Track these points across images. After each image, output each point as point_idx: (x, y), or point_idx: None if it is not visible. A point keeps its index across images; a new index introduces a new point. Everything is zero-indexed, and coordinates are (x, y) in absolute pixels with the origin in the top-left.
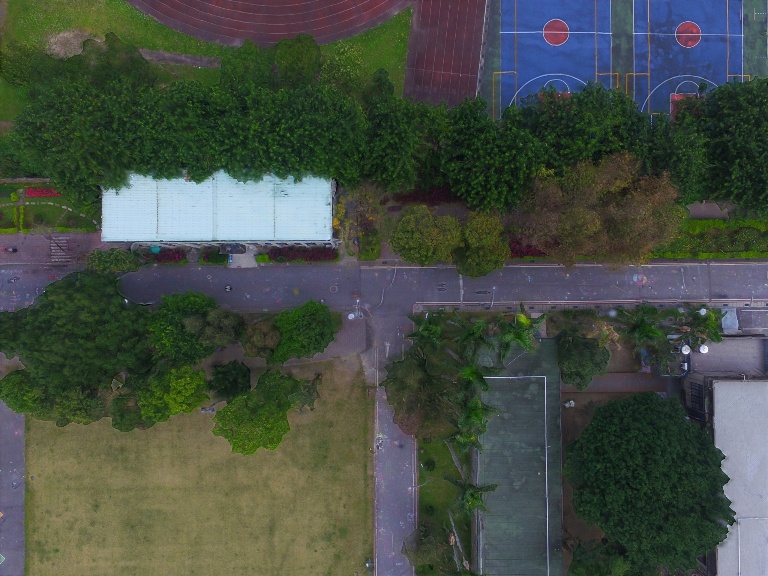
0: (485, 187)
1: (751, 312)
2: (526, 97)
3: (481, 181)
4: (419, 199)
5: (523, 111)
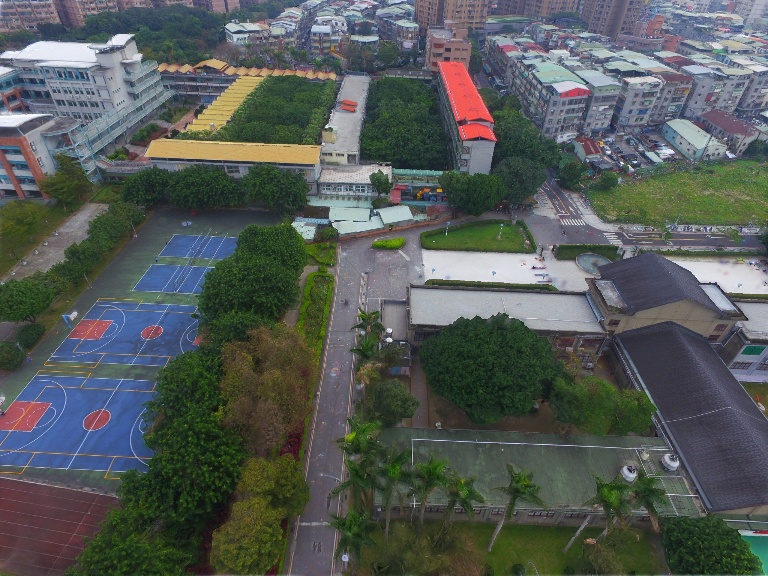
0: (216, 468)
1: (367, 312)
2: (144, 432)
3: (208, 470)
4: (208, 568)
5: (155, 432)
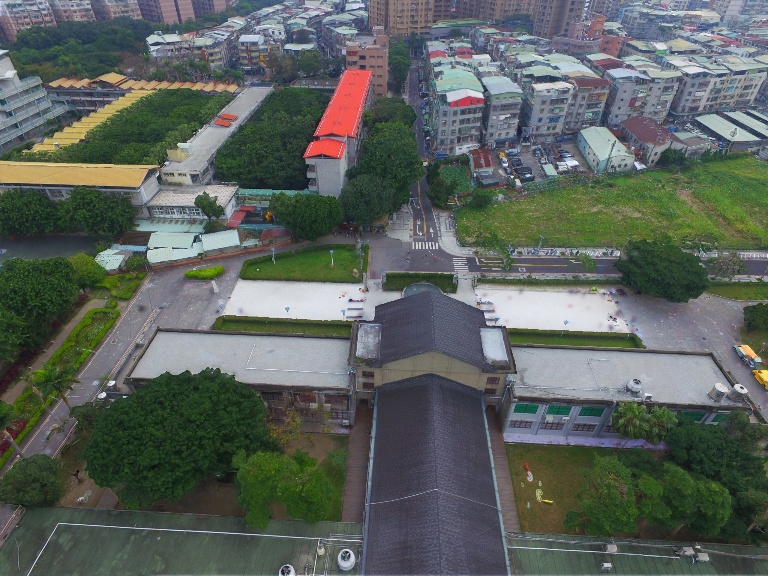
0: None
1: None
2: None
3: None
4: None
5: None
